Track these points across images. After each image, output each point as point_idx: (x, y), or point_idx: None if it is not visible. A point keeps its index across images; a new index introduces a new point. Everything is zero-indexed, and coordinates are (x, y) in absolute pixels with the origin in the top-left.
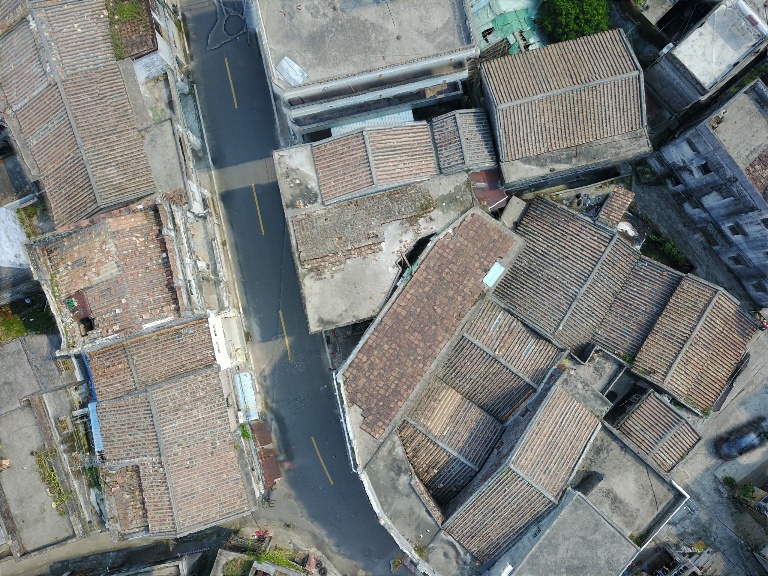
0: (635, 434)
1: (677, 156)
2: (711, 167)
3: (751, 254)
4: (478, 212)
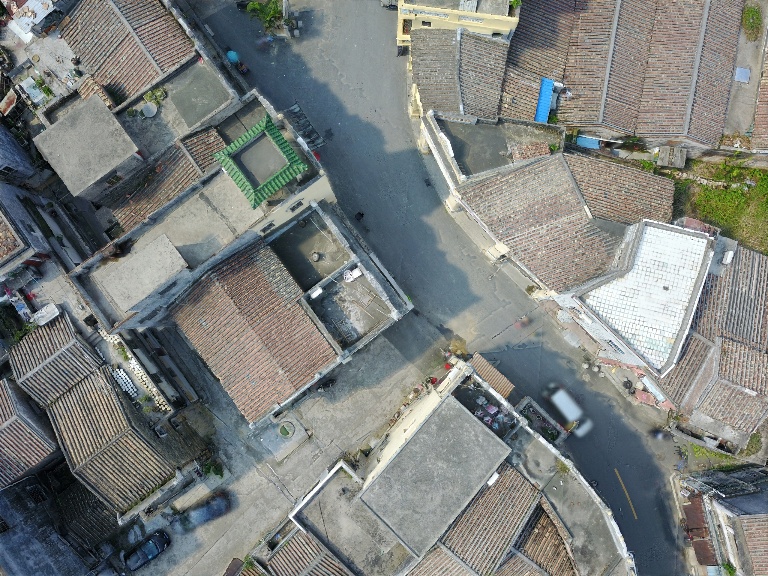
0: (335, 570)
1: None
2: None
3: None
4: None
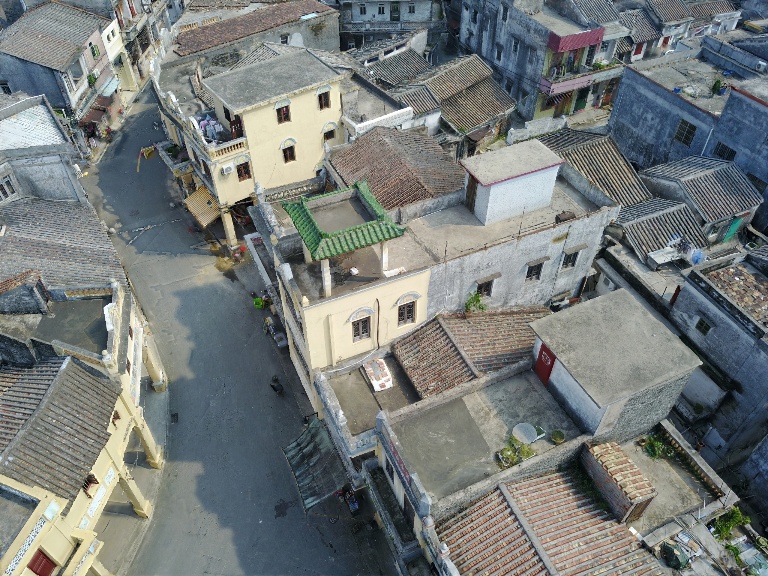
0: None
1: (465, 30)
2: (475, 8)
3: (510, 65)
4: (313, 0)
